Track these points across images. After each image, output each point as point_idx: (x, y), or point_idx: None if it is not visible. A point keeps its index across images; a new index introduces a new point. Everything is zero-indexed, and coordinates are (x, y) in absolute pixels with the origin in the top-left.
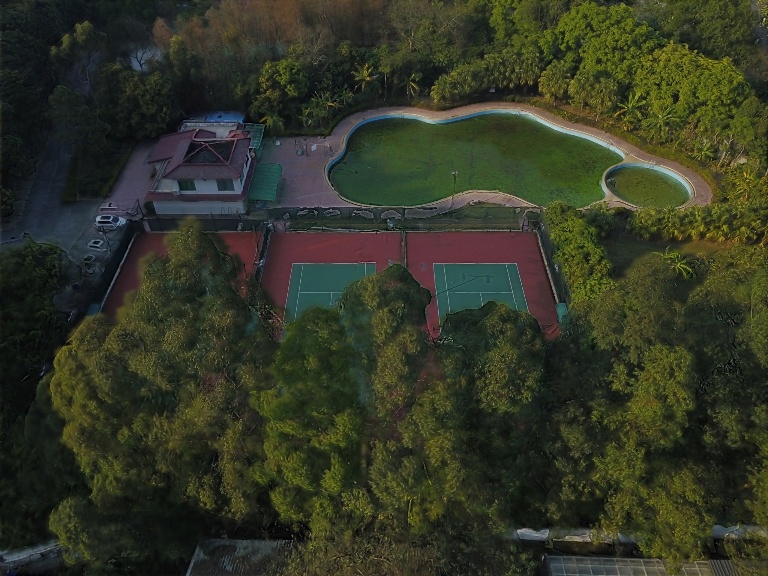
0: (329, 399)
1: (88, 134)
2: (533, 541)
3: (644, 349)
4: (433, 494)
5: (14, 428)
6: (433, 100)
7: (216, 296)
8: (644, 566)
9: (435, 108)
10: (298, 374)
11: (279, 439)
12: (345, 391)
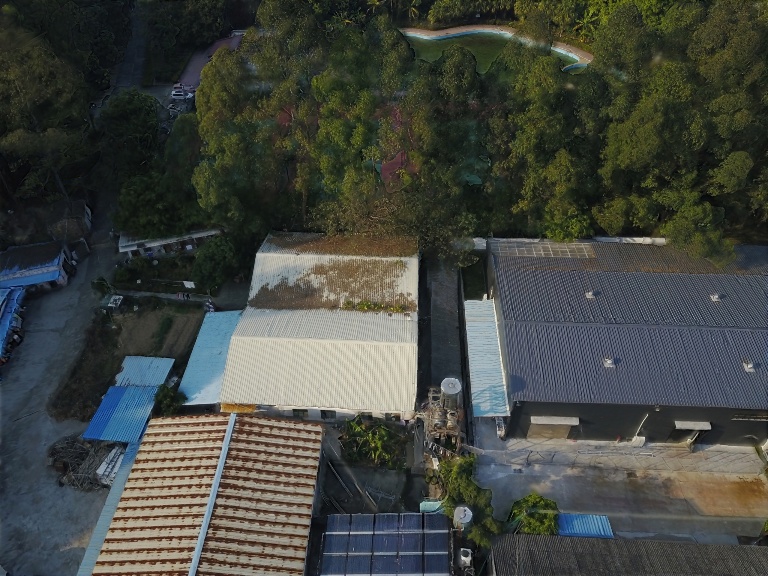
0: (356, 80)
1: (163, 33)
2: (484, 250)
3: (531, 62)
4: (414, 155)
5: (152, 164)
6: (430, 22)
7: (300, 7)
8: (550, 245)
9: (431, 28)
10: (340, 60)
11: (327, 114)
12: (365, 80)
